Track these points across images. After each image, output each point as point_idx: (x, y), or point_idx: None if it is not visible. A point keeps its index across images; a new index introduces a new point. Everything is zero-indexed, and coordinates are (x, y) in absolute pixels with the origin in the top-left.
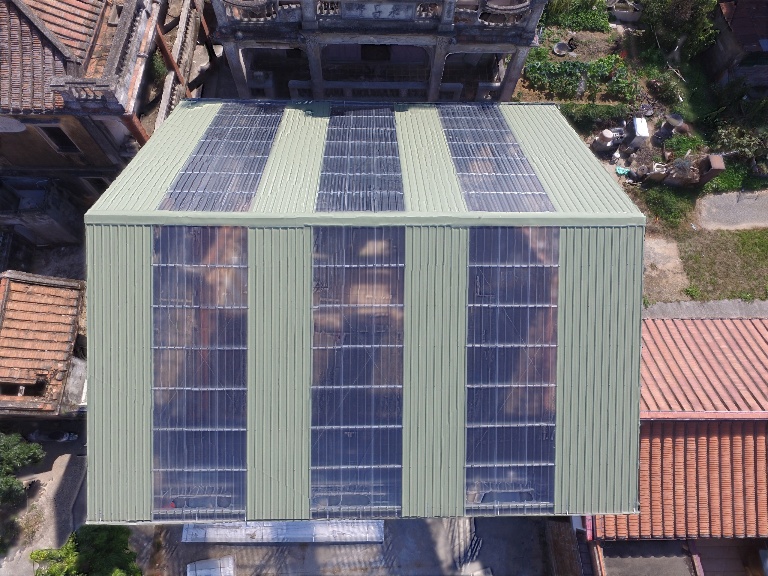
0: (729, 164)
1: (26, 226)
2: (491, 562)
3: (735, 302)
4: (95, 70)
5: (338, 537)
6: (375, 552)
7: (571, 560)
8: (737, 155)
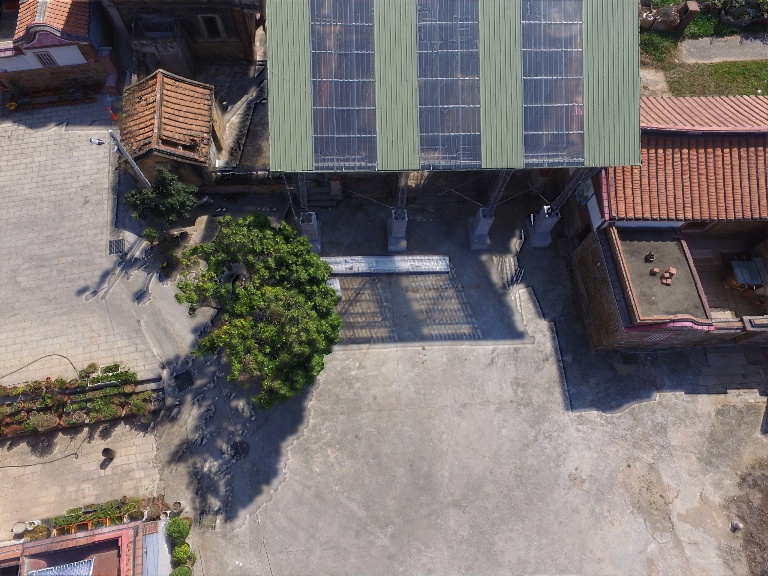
0: (703, 15)
1: (157, 56)
2: (531, 283)
3: None
4: None
5: (415, 268)
6: (444, 279)
7: (593, 257)
8: (709, 7)
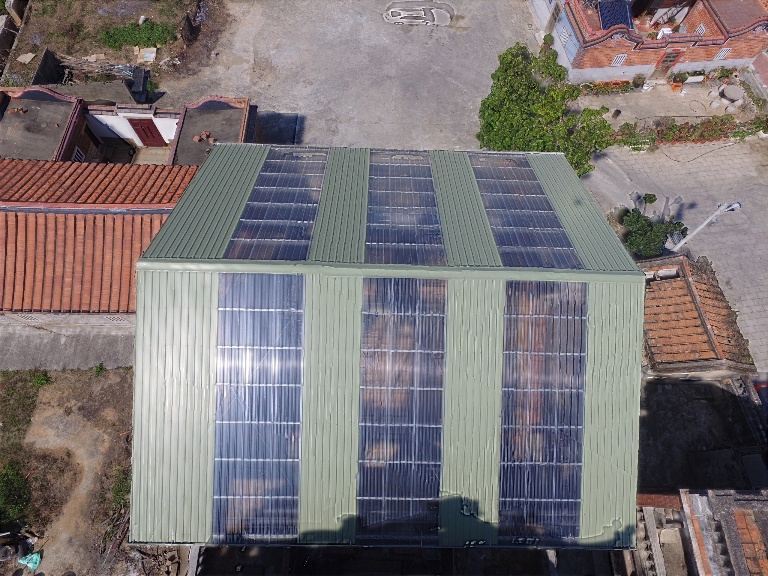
0: None
1: None
2: None
3: (3, 367)
4: (759, 564)
5: None
6: None
7: None
8: None
